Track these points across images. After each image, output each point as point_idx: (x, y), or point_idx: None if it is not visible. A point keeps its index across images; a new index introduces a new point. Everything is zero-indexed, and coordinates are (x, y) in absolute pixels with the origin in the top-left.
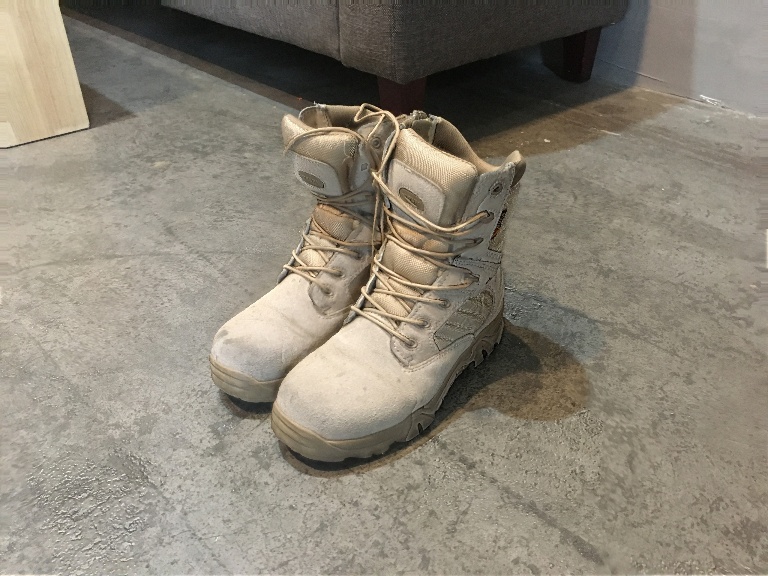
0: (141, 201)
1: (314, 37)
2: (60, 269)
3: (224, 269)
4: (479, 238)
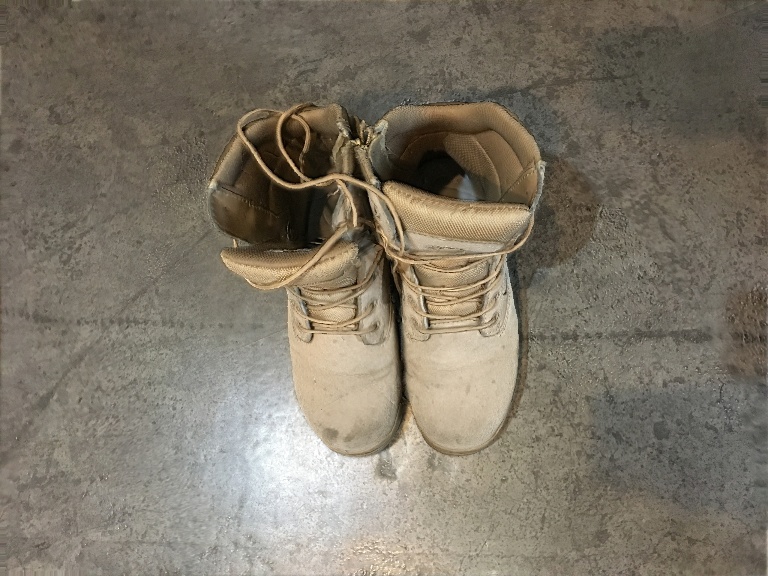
0: None
1: None
2: (23, 461)
3: (166, 319)
4: None
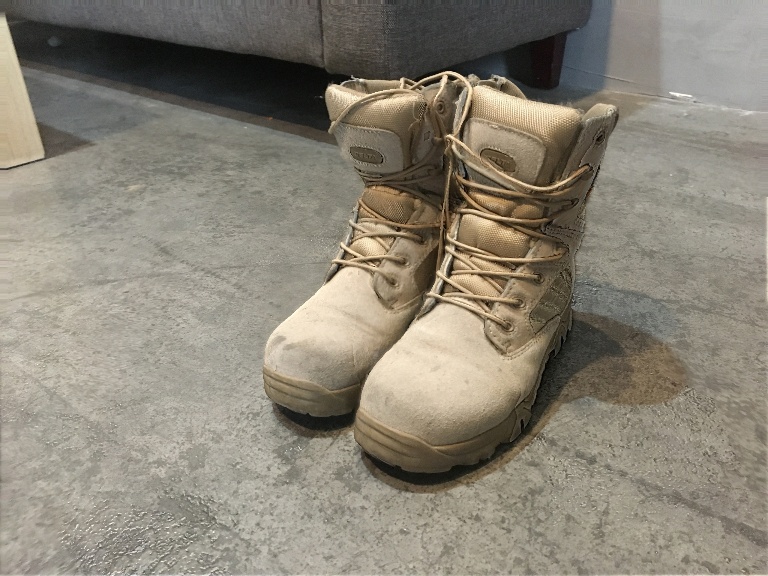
0: (123, 224)
1: (293, 45)
2: (45, 300)
3: (239, 284)
4: (576, 199)
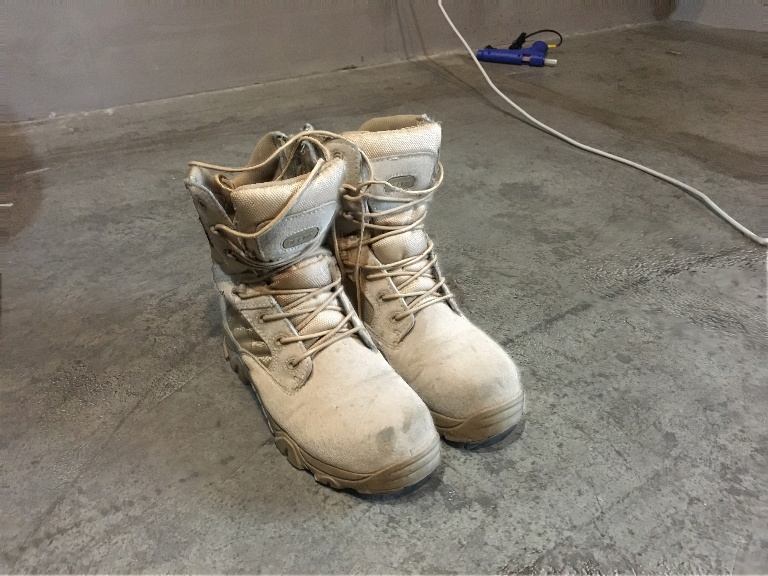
0: None
1: None
2: None
3: (106, 508)
4: None
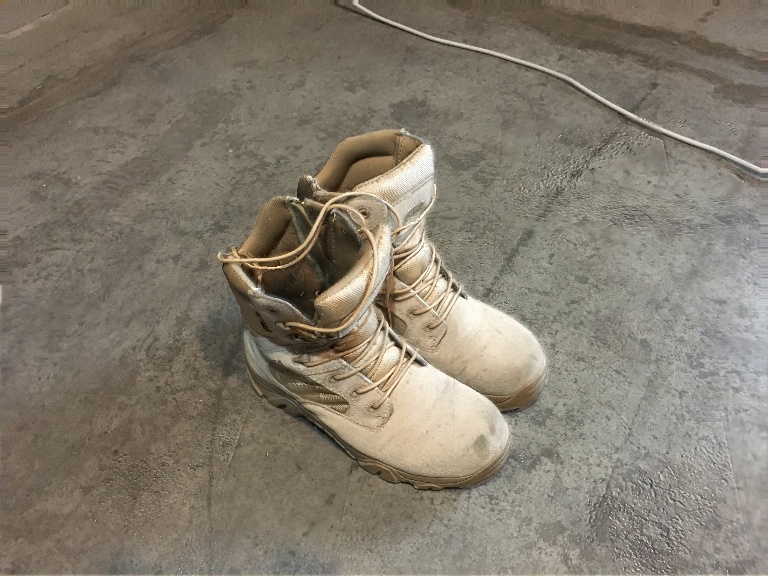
0: None
1: None
2: None
3: None
4: None
